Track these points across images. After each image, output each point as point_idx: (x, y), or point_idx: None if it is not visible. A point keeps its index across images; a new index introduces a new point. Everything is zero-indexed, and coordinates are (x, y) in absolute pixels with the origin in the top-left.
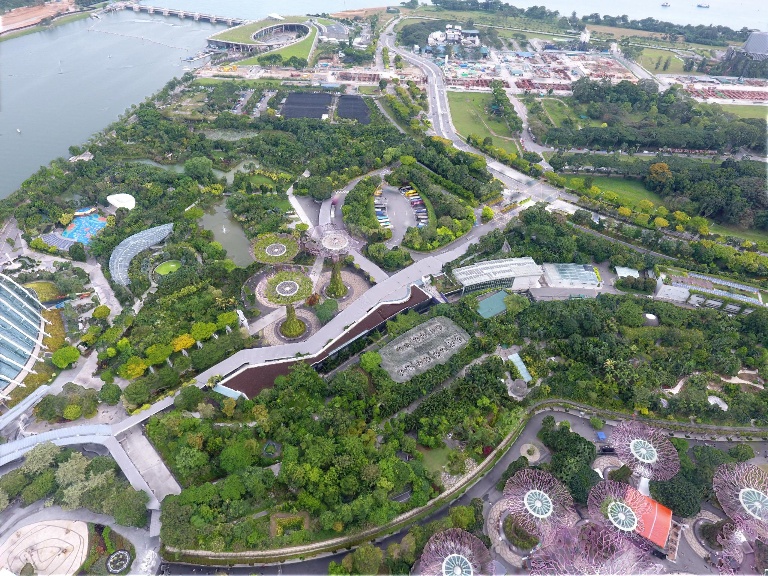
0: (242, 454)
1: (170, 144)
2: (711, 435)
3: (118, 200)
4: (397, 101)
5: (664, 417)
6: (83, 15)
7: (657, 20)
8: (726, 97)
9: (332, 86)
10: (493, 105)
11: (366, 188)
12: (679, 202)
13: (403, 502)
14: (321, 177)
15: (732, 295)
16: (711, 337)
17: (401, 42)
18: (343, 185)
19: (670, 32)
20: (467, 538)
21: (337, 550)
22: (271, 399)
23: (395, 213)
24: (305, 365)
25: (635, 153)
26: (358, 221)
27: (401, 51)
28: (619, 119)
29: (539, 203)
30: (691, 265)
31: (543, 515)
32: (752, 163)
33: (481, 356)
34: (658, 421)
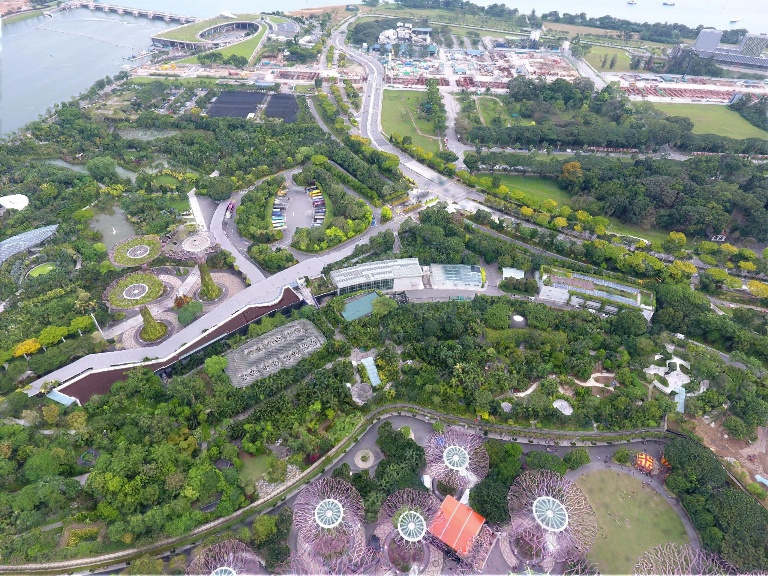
0: (48, 463)
1: (82, 144)
2: (554, 440)
3: (12, 201)
4: (326, 100)
5: (505, 422)
6: (35, 13)
7: (615, 18)
8: (666, 95)
9: (267, 85)
10: (426, 104)
11: (266, 188)
12: (584, 201)
13: (209, 511)
14: (224, 177)
15: (610, 296)
16: (576, 339)
17: (351, 40)
18: (248, 185)
19: (624, 30)
20: (241, 550)
21: (131, 562)
22: (101, 405)
23: (294, 213)
24: (142, 370)
25: (558, 152)
26: (248, 222)
27: (349, 49)
28: (548, 117)
29: (439, 203)
30: (576, 266)
31: (329, 525)
32: (666, 162)
33: (336, 360)
34: (498, 426)
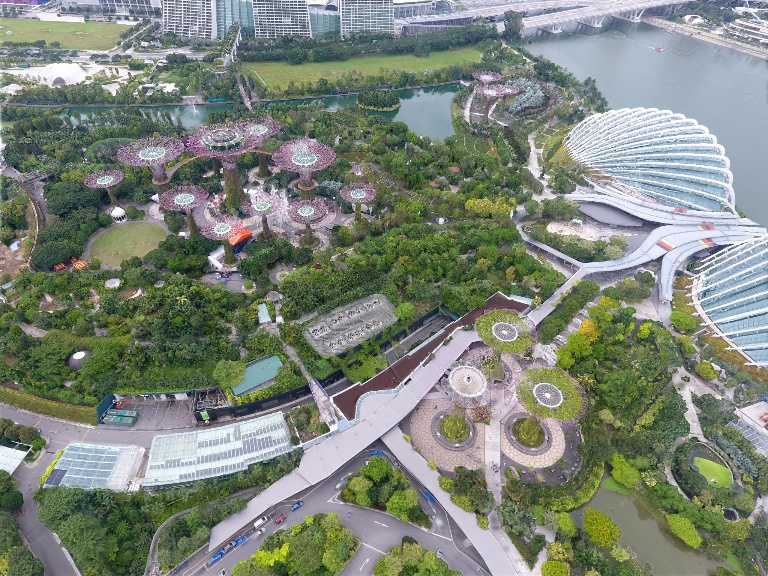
0: None
1: None
2: None
3: None
4: None
5: None
6: None
7: None
8: None
9: None
10: None
11: None
12: None
13: None
14: None
15: None
16: None
17: None
18: None
19: None
20: None
21: None
22: None
23: None
24: (462, 297)
25: None
26: None
27: None
28: None
29: None
30: None
31: None
32: None
33: None
34: None
